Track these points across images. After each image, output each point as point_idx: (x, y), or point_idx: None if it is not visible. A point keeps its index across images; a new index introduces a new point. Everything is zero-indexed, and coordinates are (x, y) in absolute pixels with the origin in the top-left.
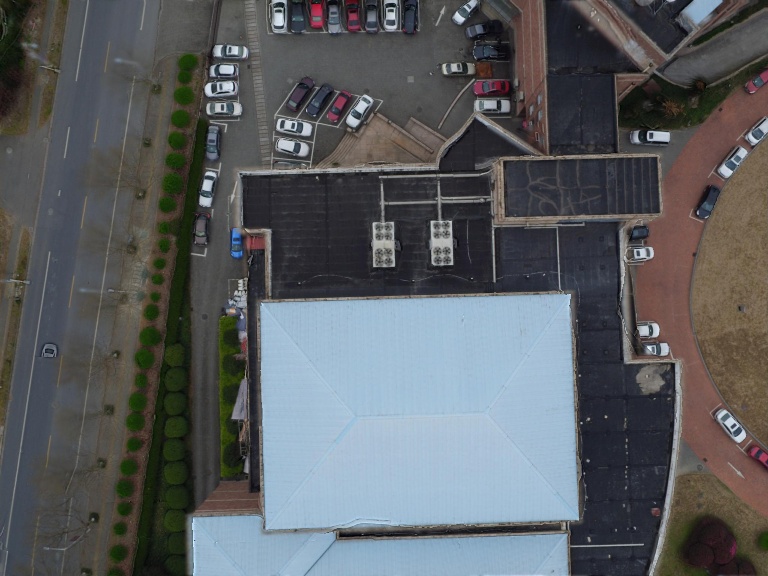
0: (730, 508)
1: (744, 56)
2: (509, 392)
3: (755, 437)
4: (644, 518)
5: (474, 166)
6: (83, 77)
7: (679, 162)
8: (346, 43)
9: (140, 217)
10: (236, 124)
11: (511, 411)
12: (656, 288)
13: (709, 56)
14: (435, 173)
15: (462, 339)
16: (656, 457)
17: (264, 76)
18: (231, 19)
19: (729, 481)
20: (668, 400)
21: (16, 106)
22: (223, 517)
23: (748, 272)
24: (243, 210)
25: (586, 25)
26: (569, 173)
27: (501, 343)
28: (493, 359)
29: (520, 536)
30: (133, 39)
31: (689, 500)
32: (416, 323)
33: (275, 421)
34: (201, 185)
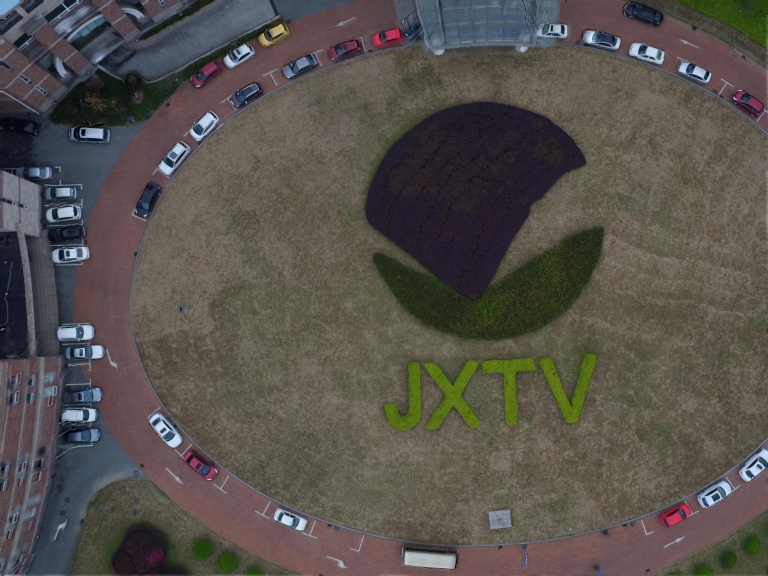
0: (167, 515)
1: (202, 49)
2: None
3: (194, 441)
4: None
5: None
6: None
7: (123, 159)
8: None
9: None
10: None
11: None
12: (95, 289)
13: (168, 50)
14: None
15: None
16: None
17: None
18: None
19: (167, 487)
20: None
21: None
22: None
23: (191, 271)
24: None
25: None
26: None
27: None
28: None
29: None
30: None
31: (125, 507)
32: None
33: None
34: None
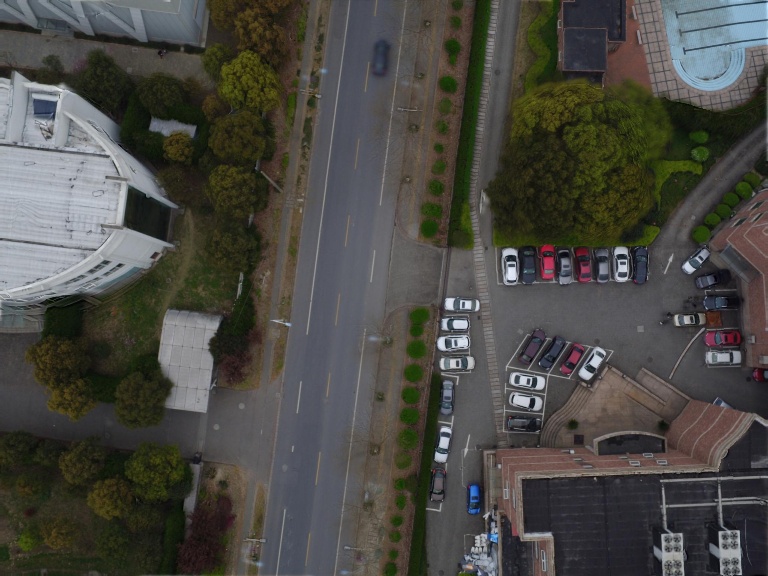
0: None
1: None
2: None
3: None
4: None
5: (750, 464)
6: (314, 330)
7: None
8: (576, 293)
9: (375, 473)
10: (468, 376)
11: None
12: None
13: None
14: (716, 476)
15: None
16: None
17: (494, 327)
18: (460, 269)
19: None
20: None
21: (250, 364)
22: None
23: None
24: (523, 514)
25: None
26: None
27: None
28: None
29: None
30: (364, 292)
31: None
32: None
33: None
34: (438, 443)
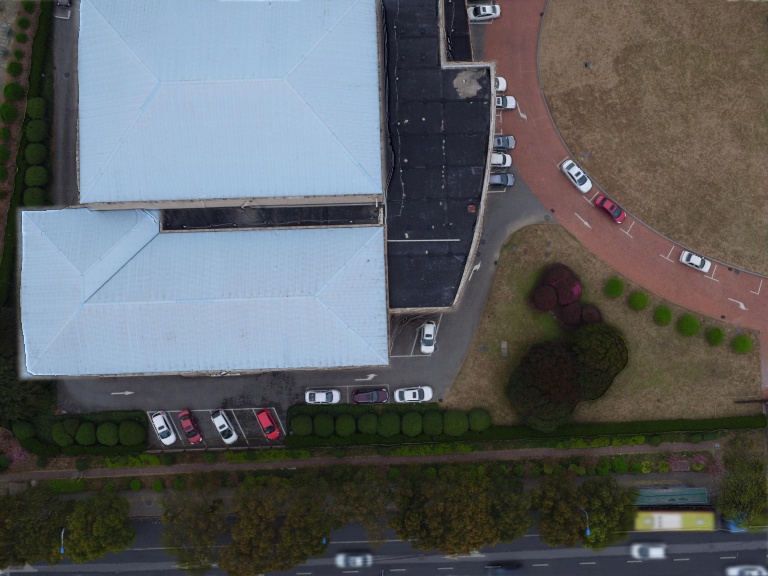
0: (577, 257)
1: None
2: (309, 62)
3: (601, 188)
4: (461, 216)
5: None
6: None
7: None
8: None
9: None
10: None
11: (311, 80)
12: (504, 46)
13: None
14: None
15: (268, 18)
16: (473, 158)
17: None
18: None
19: (576, 231)
20: (485, 104)
21: None
22: (51, 211)
23: (594, 31)
24: None
25: None
26: None
27: (305, 21)
28: (296, 34)
29: (337, 228)
30: None
31: (536, 249)
32: (225, 6)
33: (89, 98)
34: None
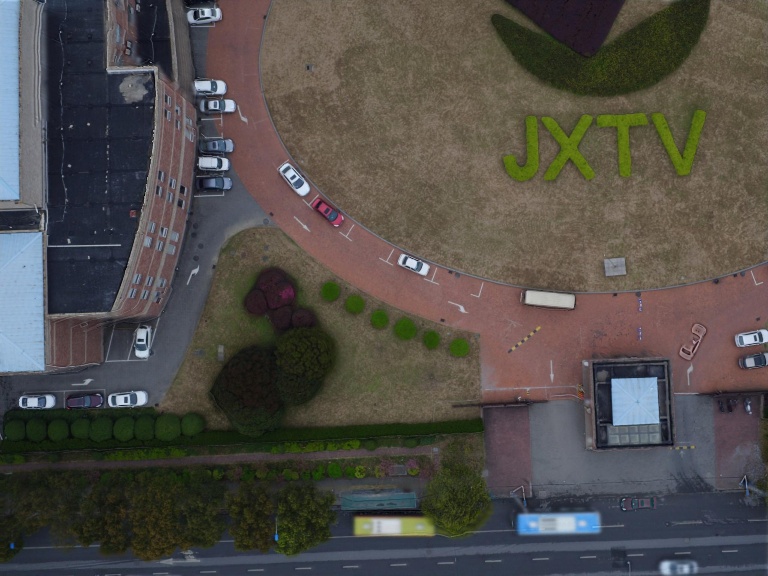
0: (295, 261)
1: None
2: None
3: (321, 191)
4: (124, 221)
5: None
6: None
7: None
8: None
9: None
10: None
11: None
12: (227, 49)
13: None
14: None
15: None
16: (137, 163)
17: None
18: None
19: (295, 234)
20: (151, 109)
21: None
22: None
23: (317, 33)
24: None
25: None
26: None
27: None
28: None
29: None
30: None
31: (254, 253)
32: None
33: None
34: None
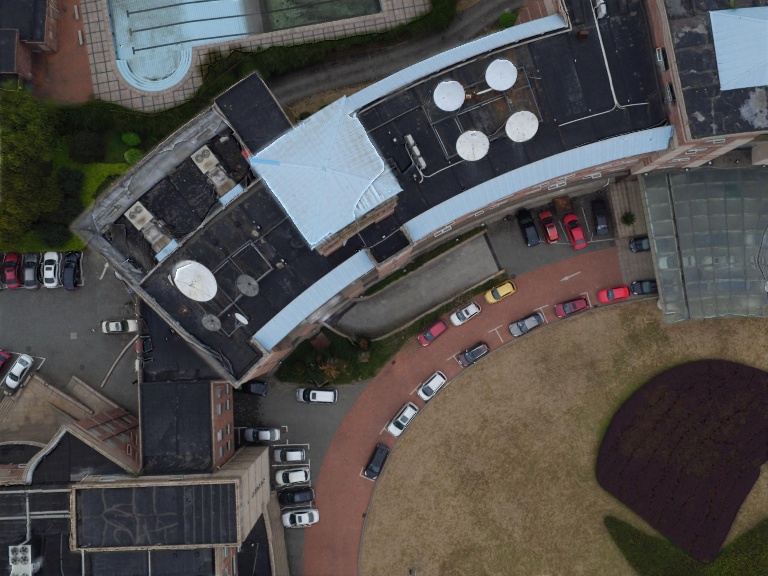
0: None
1: (424, 302)
2: None
3: None
4: None
5: (70, 476)
6: None
7: (350, 418)
8: (8, 299)
9: None
10: None
11: None
12: (324, 551)
13: (389, 301)
14: (23, 489)
15: None
16: None
17: None
18: None
19: None
20: None
21: None
22: None
23: (420, 533)
24: None
25: (172, 338)
26: (145, 500)
27: None
28: None
29: None
30: None
31: None
32: None
33: None
34: None
